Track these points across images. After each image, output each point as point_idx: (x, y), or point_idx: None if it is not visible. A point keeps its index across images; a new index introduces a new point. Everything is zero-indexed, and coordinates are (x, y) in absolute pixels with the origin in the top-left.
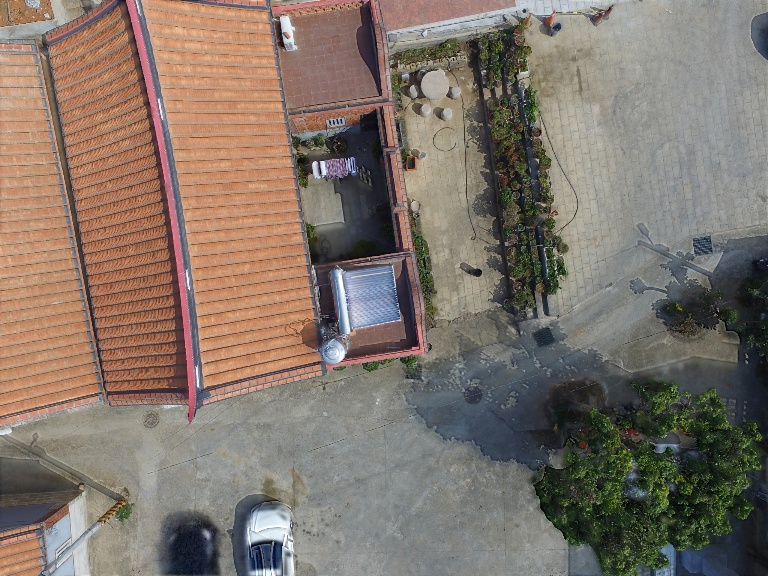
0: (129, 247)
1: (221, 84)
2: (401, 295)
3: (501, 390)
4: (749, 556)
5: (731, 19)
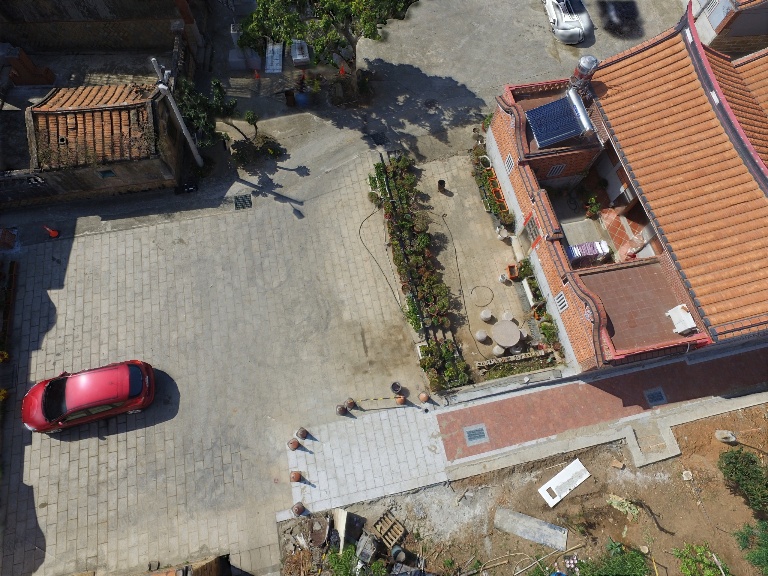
0: (759, 137)
1: (735, 249)
2: (527, 129)
3: (410, 106)
4: (212, 7)
5: (201, 414)
